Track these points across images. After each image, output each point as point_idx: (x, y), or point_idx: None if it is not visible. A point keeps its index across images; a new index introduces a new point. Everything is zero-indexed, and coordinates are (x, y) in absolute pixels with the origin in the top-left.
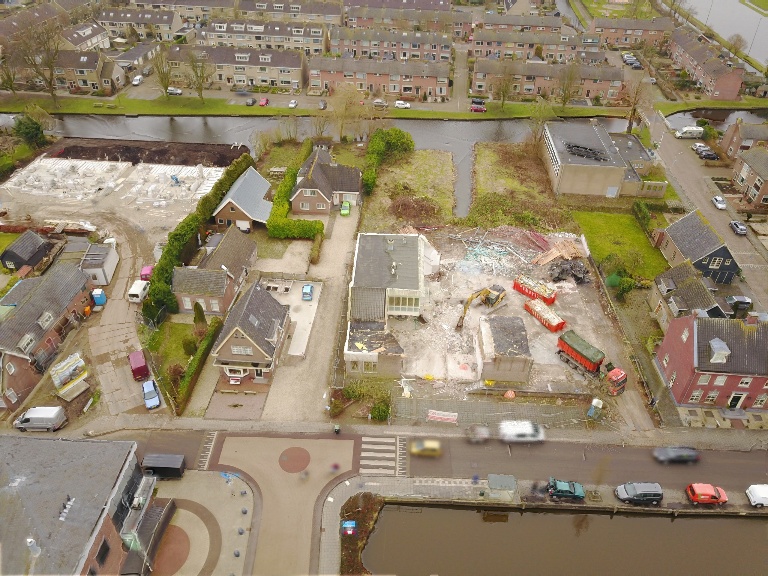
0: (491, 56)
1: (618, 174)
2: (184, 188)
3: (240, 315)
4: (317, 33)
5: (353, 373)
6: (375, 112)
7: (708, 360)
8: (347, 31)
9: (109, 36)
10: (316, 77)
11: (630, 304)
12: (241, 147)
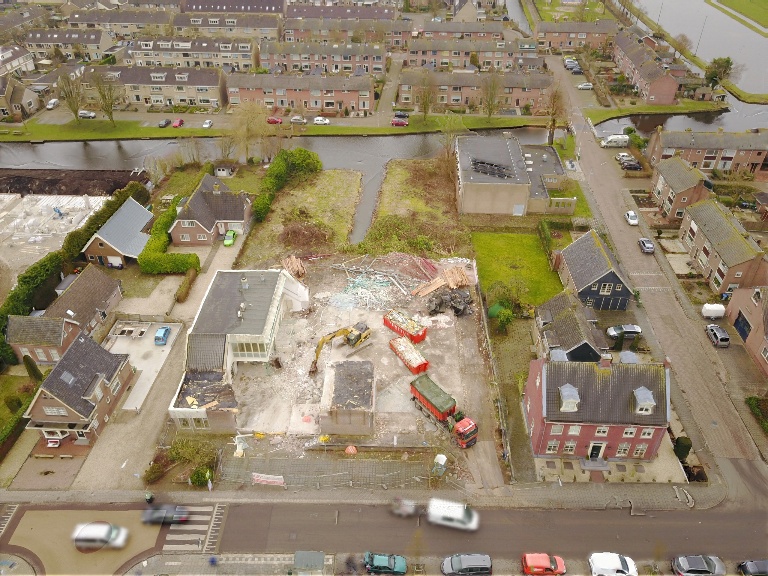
0: (427, 65)
1: (522, 191)
2: (64, 221)
3: (50, 373)
4: (245, 48)
5: (185, 430)
6: (283, 131)
7: (558, 409)
8: (276, 45)
9: (36, 58)
10: (235, 95)
11: (512, 337)
12: (141, 173)
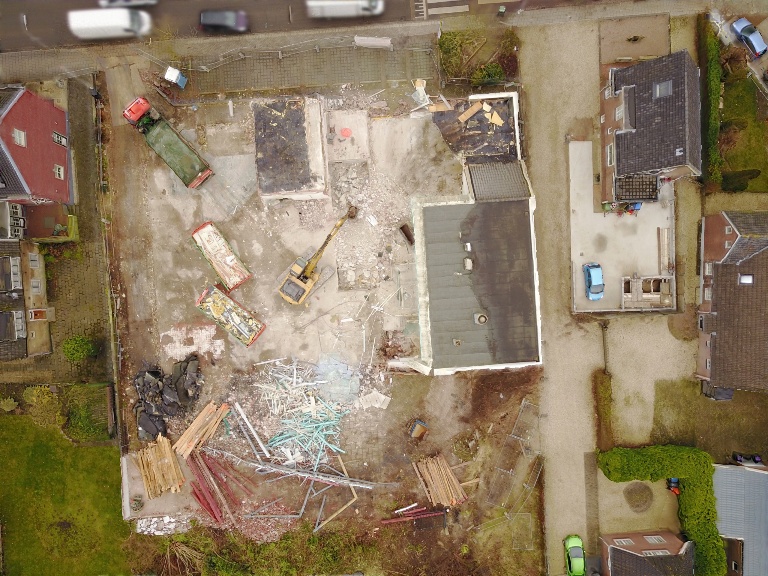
0: None
1: None
2: None
3: None
4: None
5: None
6: None
7: (2, 98)
8: None
9: None
10: None
11: None
12: None
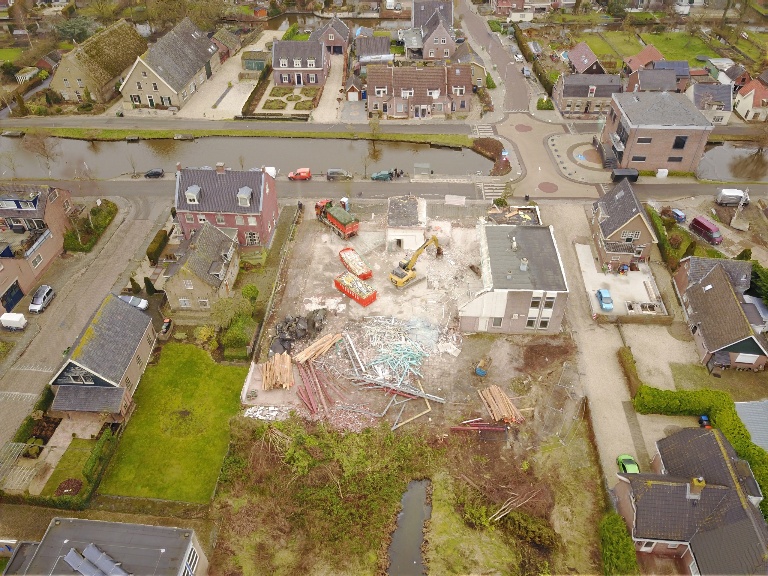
0: None
1: None
2: None
3: None
4: None
5: None
6: None
7: None
8: None
9: None
10: None
11: None
12: None
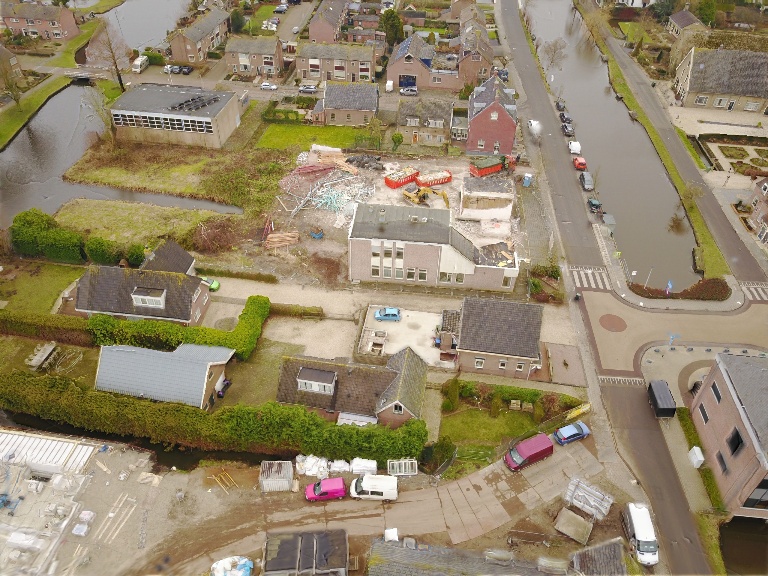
0: None
1: (235, 102)
2: (57, 478)
3: (523, 308)
4: None
5: None
6: None
7: None
8: None
9: None
10: None
11: (401, 151)
12: None
